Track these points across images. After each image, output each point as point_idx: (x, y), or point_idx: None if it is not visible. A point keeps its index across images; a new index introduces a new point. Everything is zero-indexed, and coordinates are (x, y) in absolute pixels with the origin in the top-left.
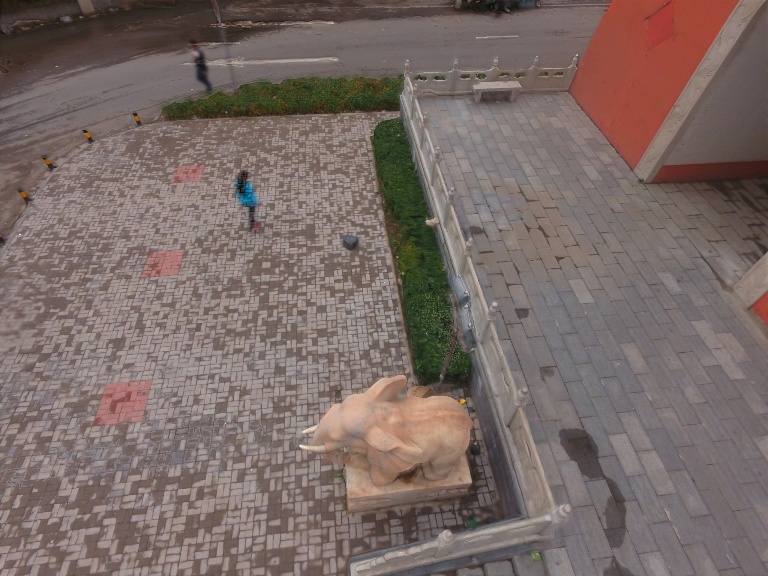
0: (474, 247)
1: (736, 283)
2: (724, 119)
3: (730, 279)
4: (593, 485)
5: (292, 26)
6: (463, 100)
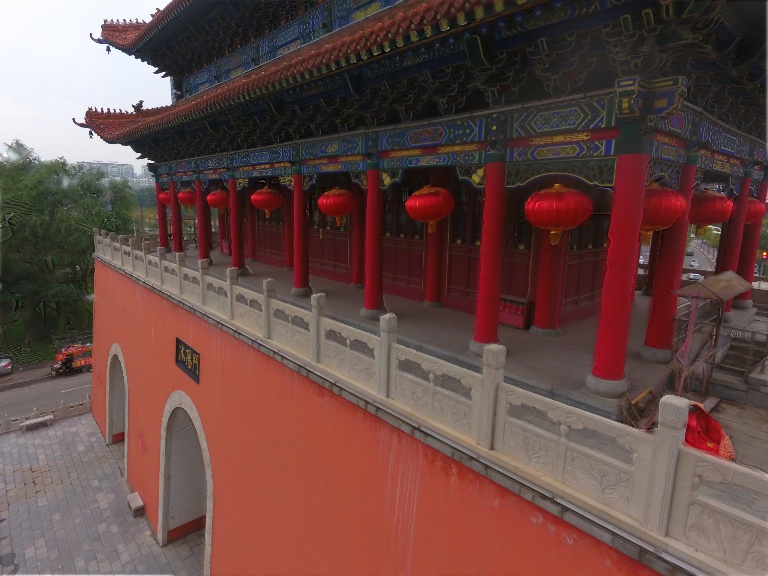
0: None
1: None
2: None
3: None
4: None
5: None
6: (15, 433)
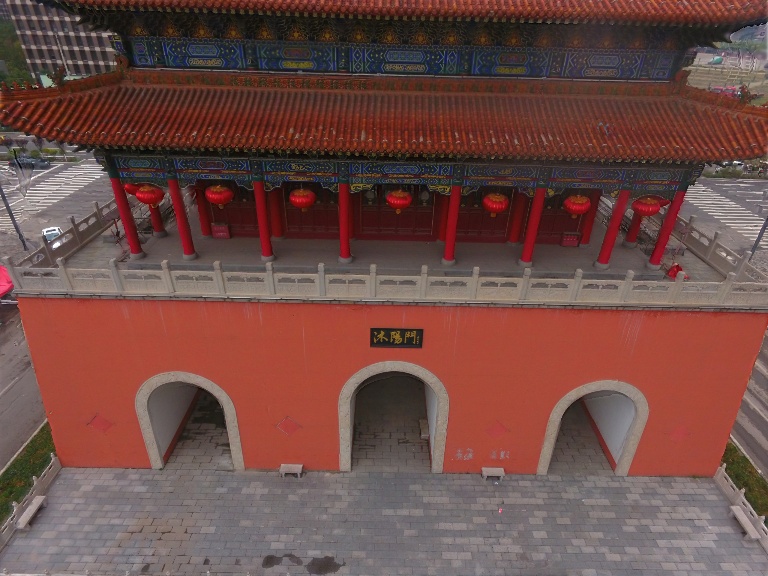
0: (157, 573)
1: (234, 467)
2: (165, 428)
3: (230, 467)
4: (283, 563)
5: None
6: (18, 539)
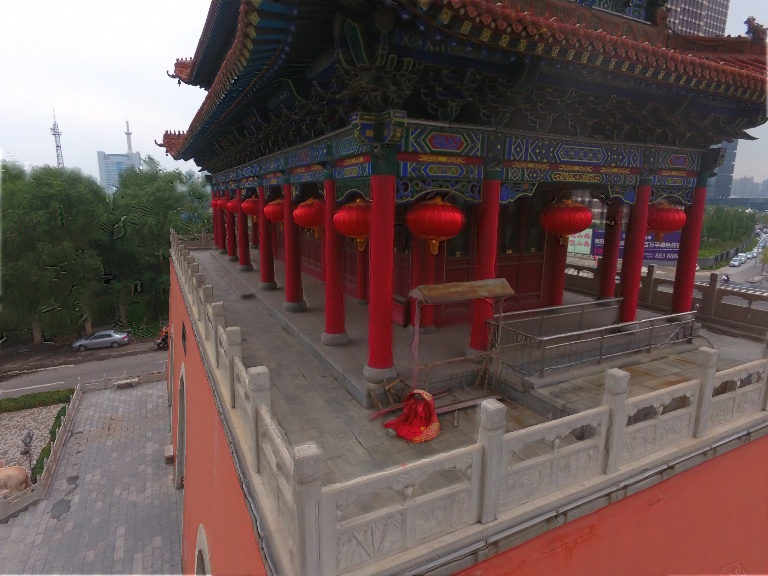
0: None
1: None
2: None
3: None
4: None
5: (45, 370)
6: (110, 390)
